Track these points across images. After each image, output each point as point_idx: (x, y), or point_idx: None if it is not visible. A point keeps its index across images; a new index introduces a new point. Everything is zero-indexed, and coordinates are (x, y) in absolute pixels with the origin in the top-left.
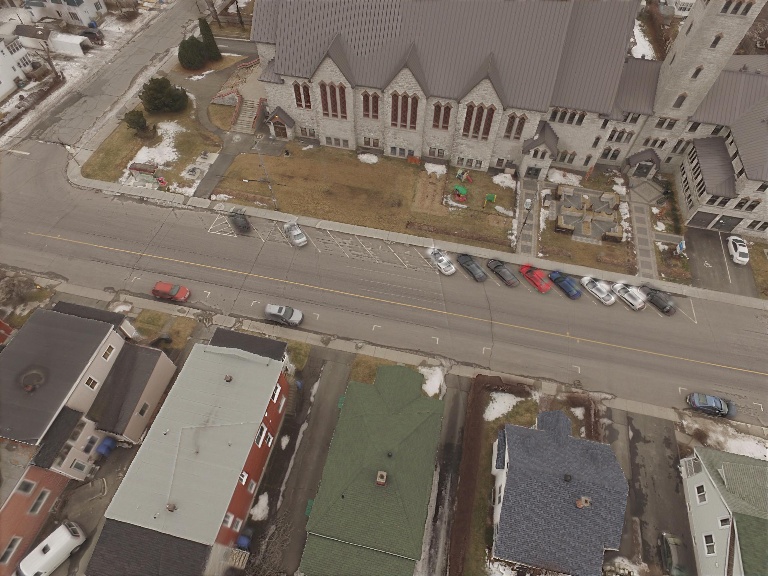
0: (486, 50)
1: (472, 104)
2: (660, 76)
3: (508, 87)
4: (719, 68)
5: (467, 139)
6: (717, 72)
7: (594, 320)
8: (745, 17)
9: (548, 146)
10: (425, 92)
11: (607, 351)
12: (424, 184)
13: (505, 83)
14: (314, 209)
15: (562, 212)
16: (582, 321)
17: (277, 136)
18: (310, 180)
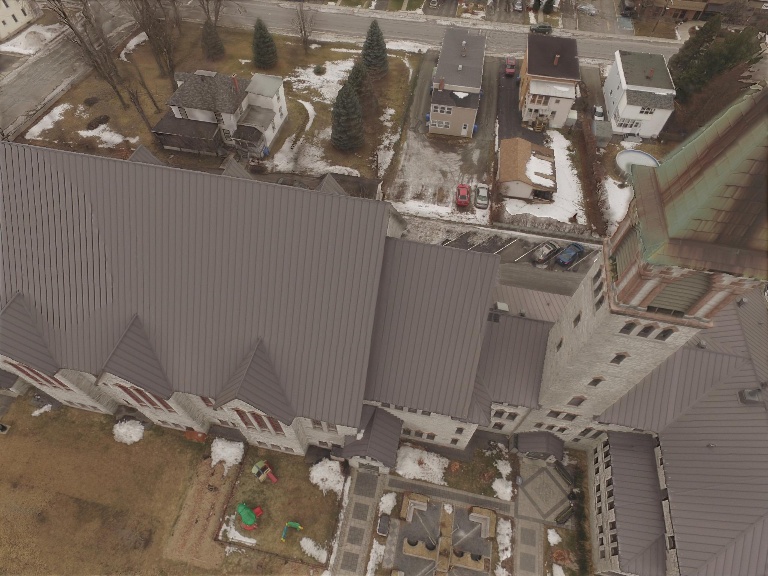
0: (250, 333)
1: (239, 409)
2: (547, 352)
3: (292, 389)
4: (630, 382)
5: (256, 431)
6: (628, 385)
7: None
8: (663, 342)
9: (374, 458)
10: (159, 394)
11: None
12: (199, 491)
13: (287, 383)
14: (4, 560)
15: (404, 553)
16: None
17: (1, 388)
18: (20, 488)
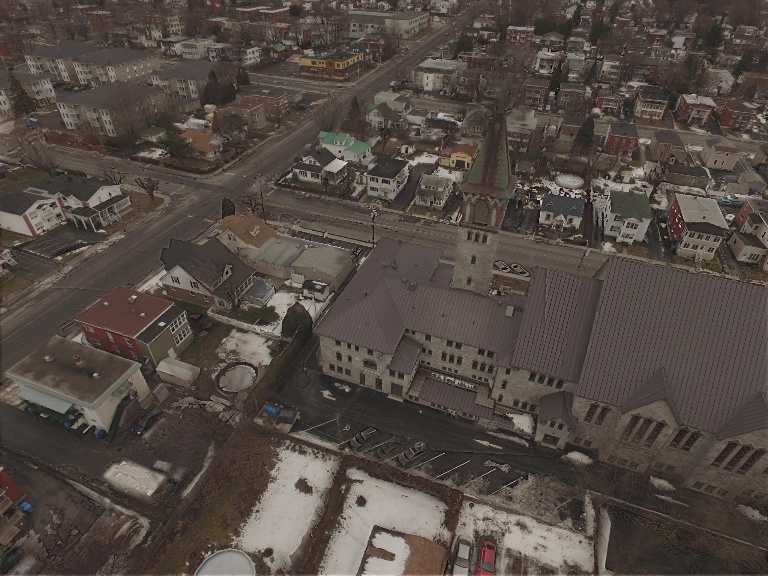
0: None
1: None
2: None
3: None
4: None
5: None
6: None
7: (526, 259)
8: None
9: None
10: None
11: (522, 249)
12: None
13: None
14: None
15: None
16: (533, 259)
17: None
18: None
